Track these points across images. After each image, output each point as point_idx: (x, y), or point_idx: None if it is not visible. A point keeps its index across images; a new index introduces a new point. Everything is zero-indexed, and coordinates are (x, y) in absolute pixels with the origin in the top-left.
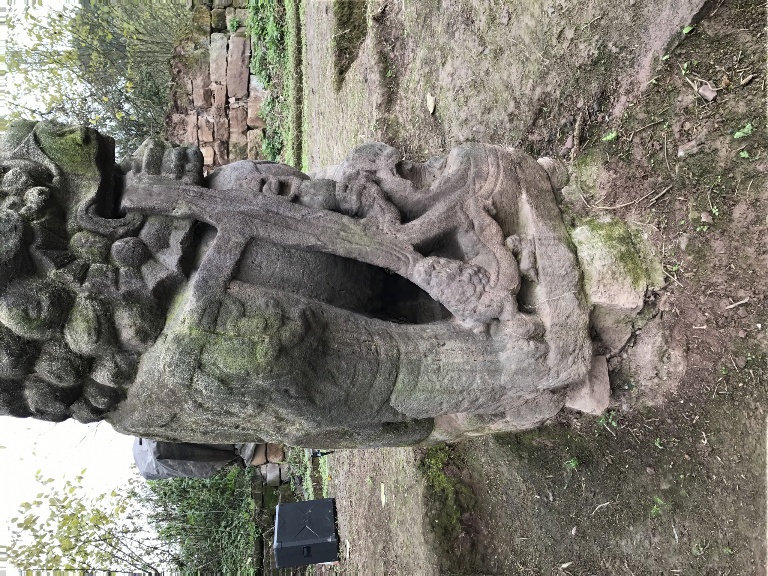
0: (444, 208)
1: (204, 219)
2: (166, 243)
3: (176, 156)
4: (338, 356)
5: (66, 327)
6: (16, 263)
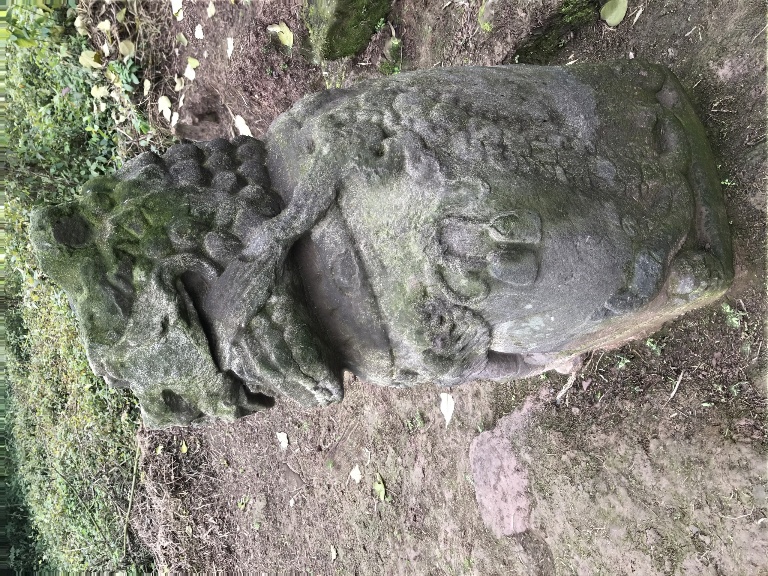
0: None
1: None
2: None
3: None
4: None
5: None
6: None
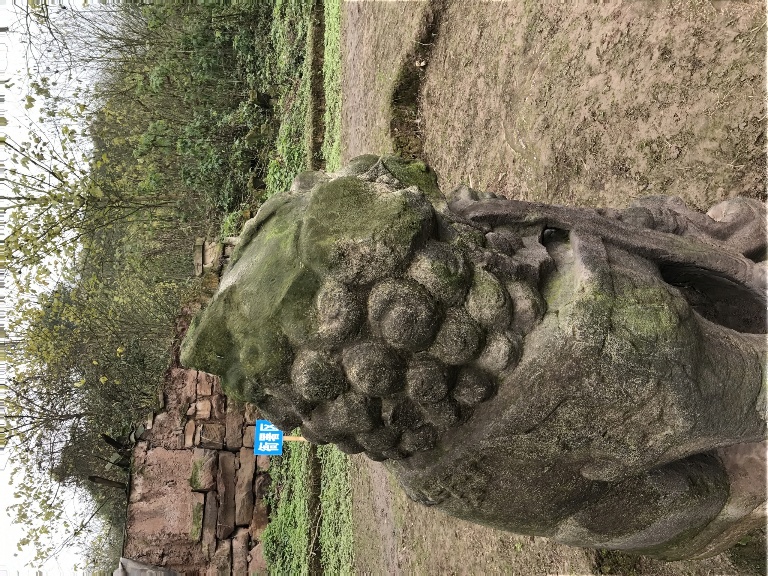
0: (751, 230)
1: (556, 223)
2: (522, 244)
3: (491, 195)
4: (711, 344)
5: (470, 292)
6: (432, 224)
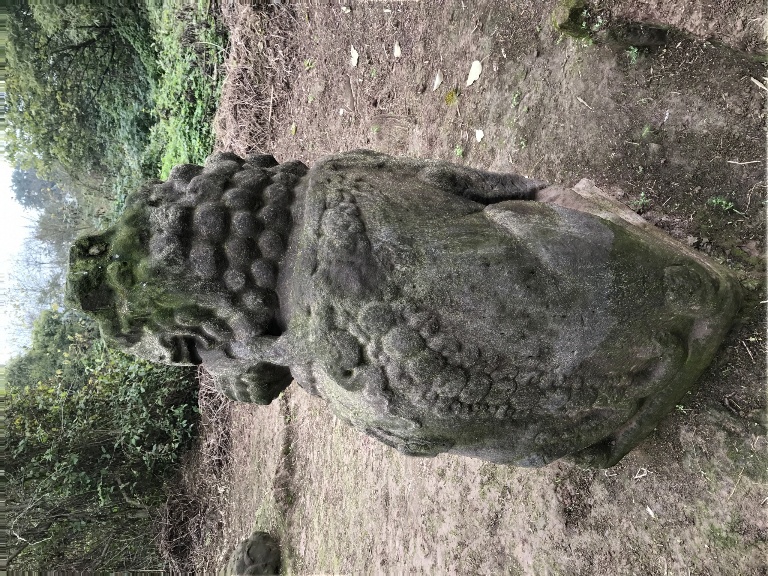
0: None
1: None
2: None
3: None
4: None
5: None
6: None
